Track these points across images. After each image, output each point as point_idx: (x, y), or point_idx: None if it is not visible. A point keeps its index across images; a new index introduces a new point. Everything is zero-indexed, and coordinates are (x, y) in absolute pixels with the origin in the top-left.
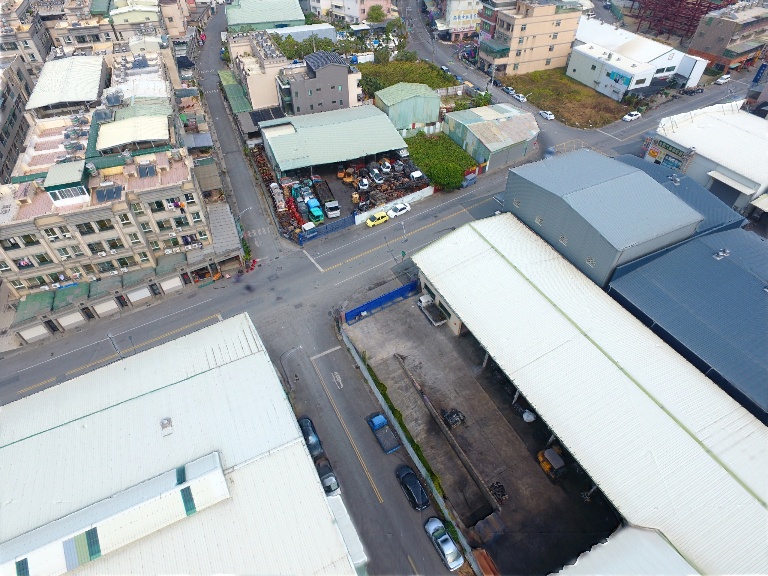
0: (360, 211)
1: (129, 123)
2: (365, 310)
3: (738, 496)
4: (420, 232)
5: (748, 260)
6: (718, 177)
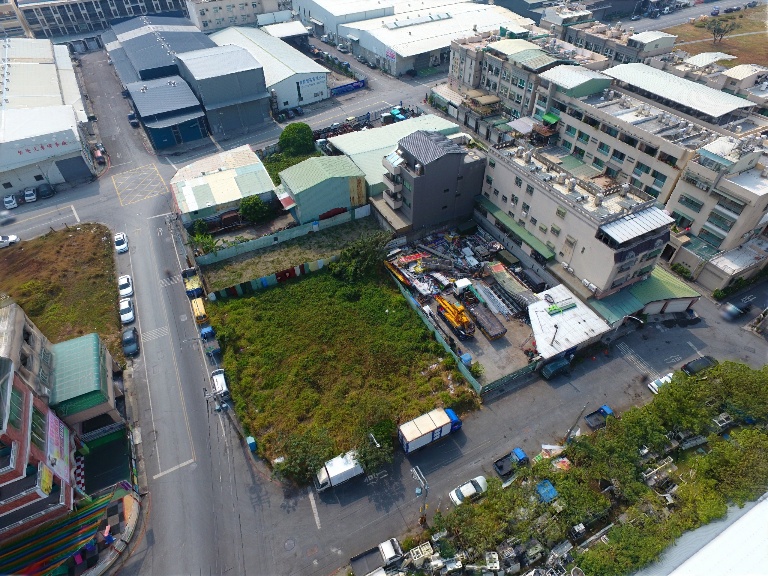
0: (366, 122)
1: (524, 46)
2: (355, 86)
3: (246, 34)
4: (323, 119)
5: (165, 61)
6: (85, 118)
